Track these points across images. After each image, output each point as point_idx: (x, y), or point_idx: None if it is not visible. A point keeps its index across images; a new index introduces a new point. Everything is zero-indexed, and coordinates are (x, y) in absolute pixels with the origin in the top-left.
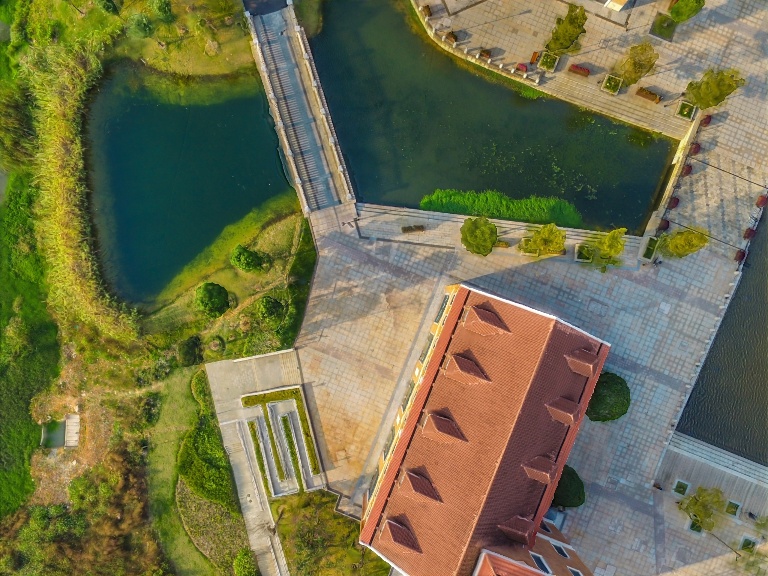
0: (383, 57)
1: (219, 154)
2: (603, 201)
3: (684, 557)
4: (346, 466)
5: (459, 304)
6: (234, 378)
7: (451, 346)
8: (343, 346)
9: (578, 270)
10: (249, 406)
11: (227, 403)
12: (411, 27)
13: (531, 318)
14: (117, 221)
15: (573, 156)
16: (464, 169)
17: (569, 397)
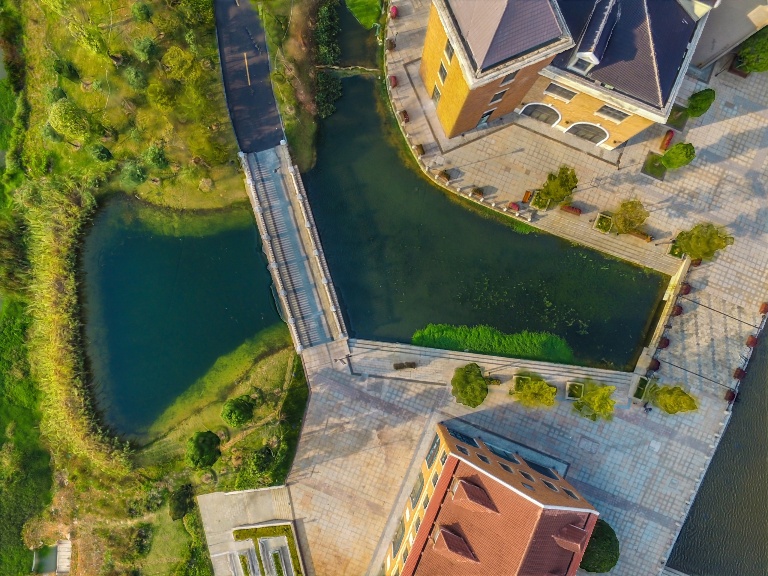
0: (376, 192)
1: (212, 286)
2: (594, 336)
3: None
4: None
5: (448, 473)
6: (226, 510)
7: (440, 516)
8: (334, 482)
9: (569, 407)
10: (240, 540)
11: (218, 535)
12: (404, 162)
13: (519, 502)
14: (110, 352)
15: (565, 290)
16: (456, 304)
17: (557, 571)
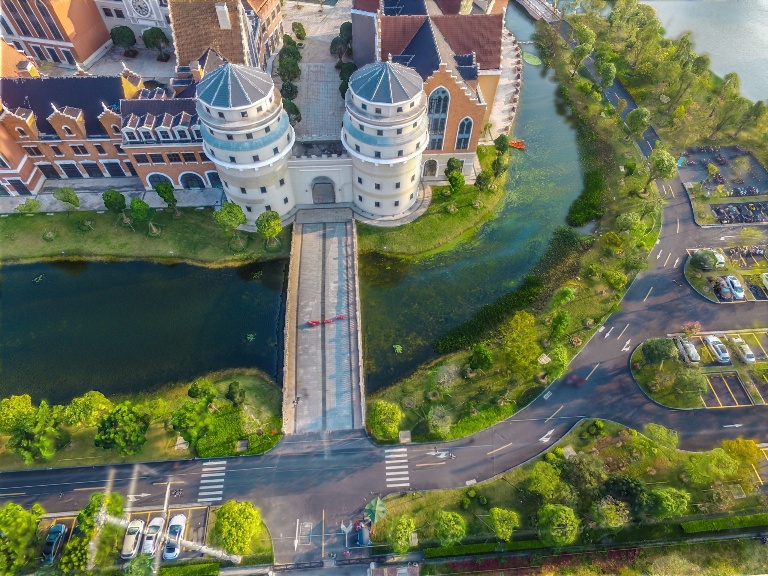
0: (506, 18)
1: (559, 3)
2: None
3: None
4: None
5: None
6: None
7: None
8: None
9: None
10: None
11: None
12: None
13: None
14: None
15: None
16: None
17: None
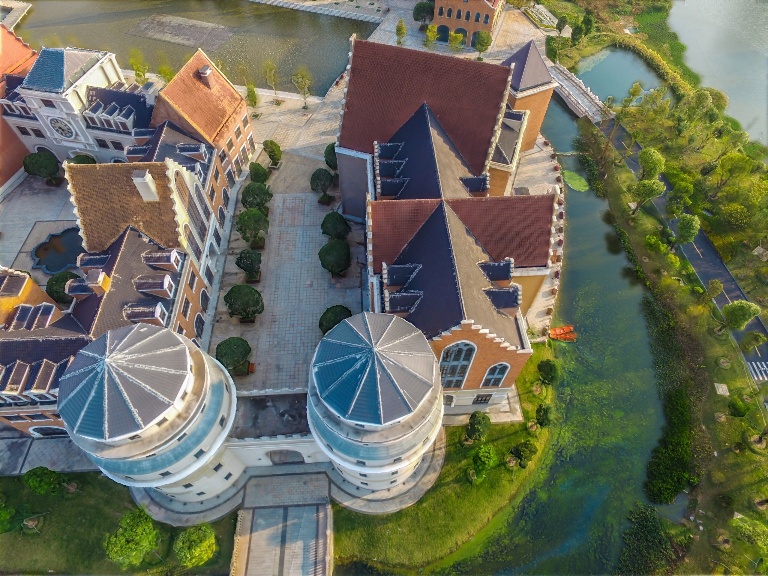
0: None
1: None
2: None
3: None
4: (514, 13)
5: (495, 5)
6: None
7: None
8: (526, 37)
9: None
10: None
11: None
12: None
13: None
14: (641, 71)
15: None
16: None
17: None
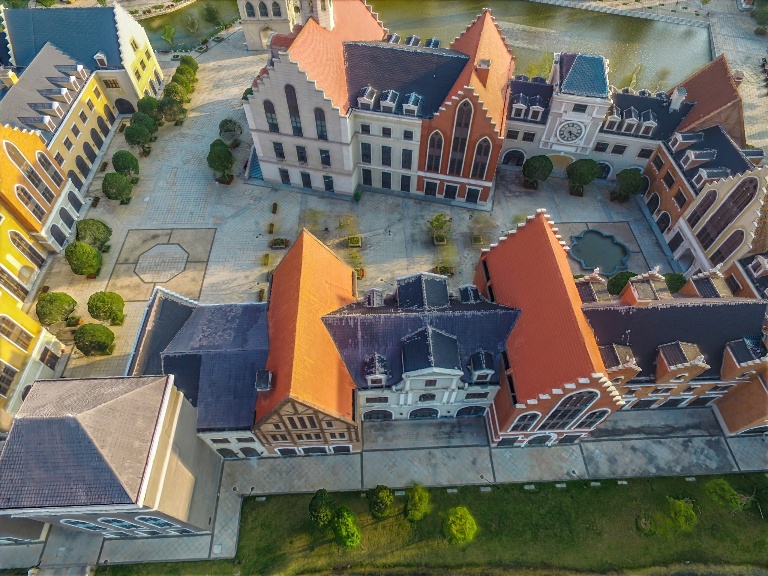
0: None
1: None
2: None
3: (685, 2)
4: None
5: None
6: None
7: None
8: None
9: None
10: None
11: None
12: None
13: None
14: None
15: None
16: None
17: None
